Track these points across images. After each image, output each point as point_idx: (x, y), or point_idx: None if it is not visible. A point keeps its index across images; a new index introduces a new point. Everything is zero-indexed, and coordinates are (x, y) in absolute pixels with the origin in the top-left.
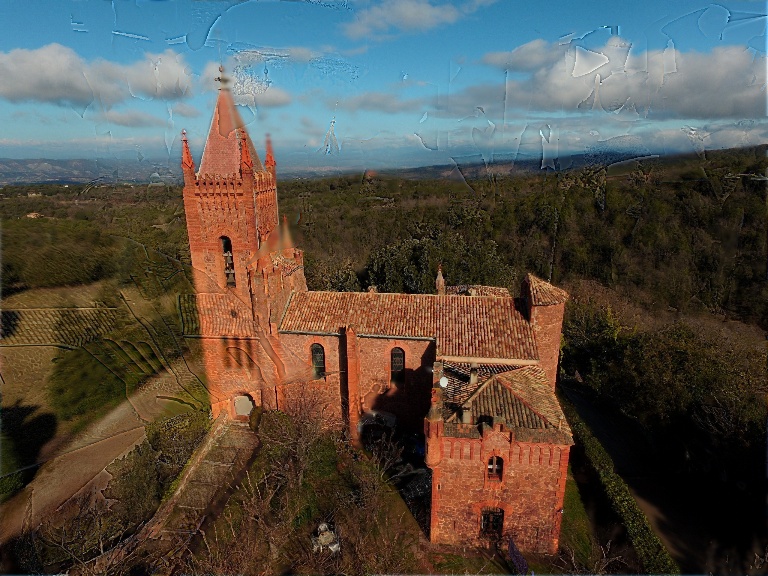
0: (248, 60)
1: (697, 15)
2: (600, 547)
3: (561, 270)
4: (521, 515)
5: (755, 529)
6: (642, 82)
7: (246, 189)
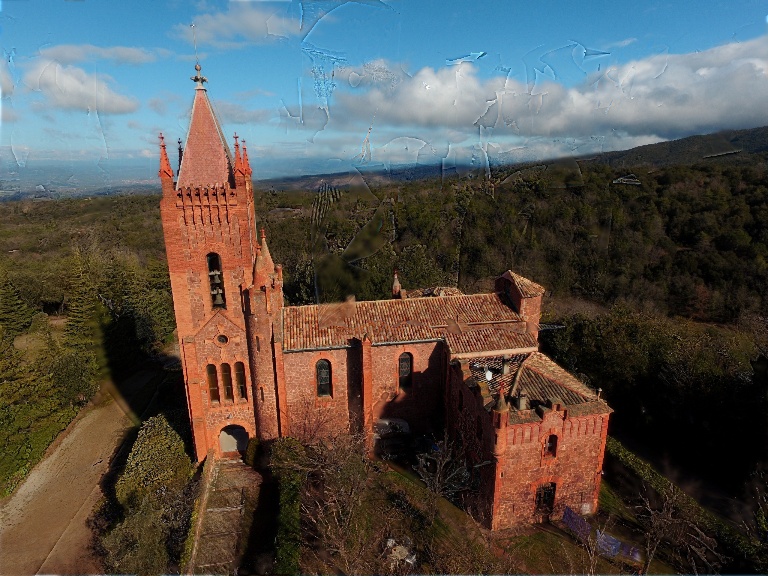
0: (321, 61)
1: (571, 49)
2: (622, 498)
3: (467, 270)
4: (569, 484)
5: (713, 457)
6: (526, 102)
7: (240, 200)
